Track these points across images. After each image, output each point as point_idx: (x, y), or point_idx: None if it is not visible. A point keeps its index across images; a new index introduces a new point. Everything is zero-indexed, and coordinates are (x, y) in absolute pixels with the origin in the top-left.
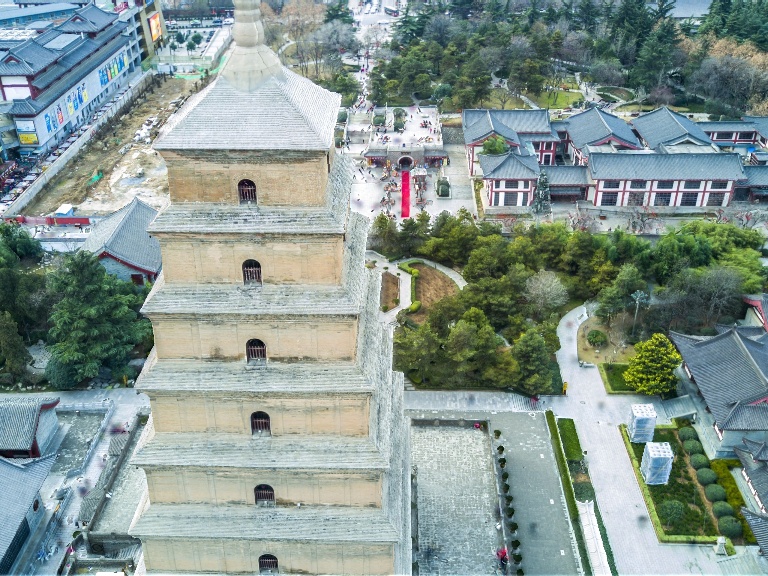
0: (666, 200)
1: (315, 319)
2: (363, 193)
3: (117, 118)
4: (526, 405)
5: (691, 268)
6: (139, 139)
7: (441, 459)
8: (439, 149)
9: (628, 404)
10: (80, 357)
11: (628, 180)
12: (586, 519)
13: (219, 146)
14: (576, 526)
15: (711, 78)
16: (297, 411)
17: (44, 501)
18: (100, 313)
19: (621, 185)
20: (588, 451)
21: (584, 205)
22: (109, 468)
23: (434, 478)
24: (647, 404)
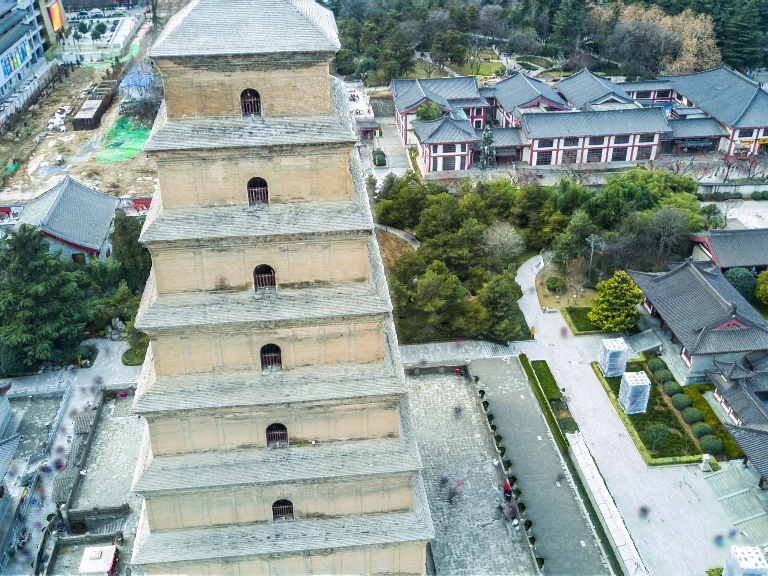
0: (598, 156)
1: (328, 237)
2: None
3: (25, 109)
4: (498, 351)
5: (638, 211)
6: (53, 128)
7: (427, 406)
8: (371, 120)
9: (595, 343)
10: (29, 338)
11: (561, 138)
12: (578, 449)
13: (221, 51)
14: (567, 458)
15: (626, 41)
16: (310, 340)
17: (8, 489)
18: (48, 290)
19: (555, 144)
20: (565, 389)
21: (520, 166)
22: (77, 447)
23: (423, 424)
24: (617, 338)
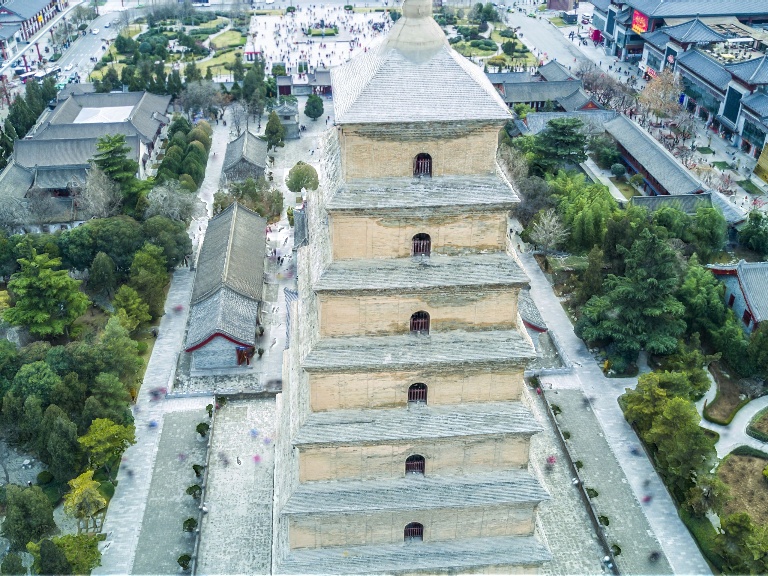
0: None
1: None
2: None
3: None
4: None
5: None
6: None
7: None
8: None
9: None
10: (593, 317)
11: None
12: None
13: None
14: None
15: None
16: None
17: None
18: (628, 296)
19: None
20: None
21: None
22: None
23: None
24: None
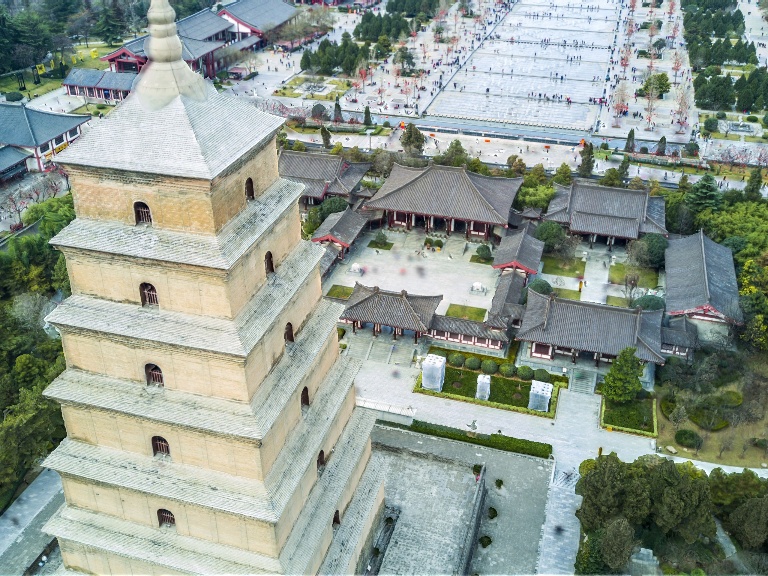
0: None
1: None
2: None
3: None
4: None
5: None
6: None
7: None
8: None
9: None
10: None
11: None
12: None
13: (243, 151)
14: None
15: None
16: None
17: None
18: None
19: None
20: None
21: None
22: None
23: None
24: None
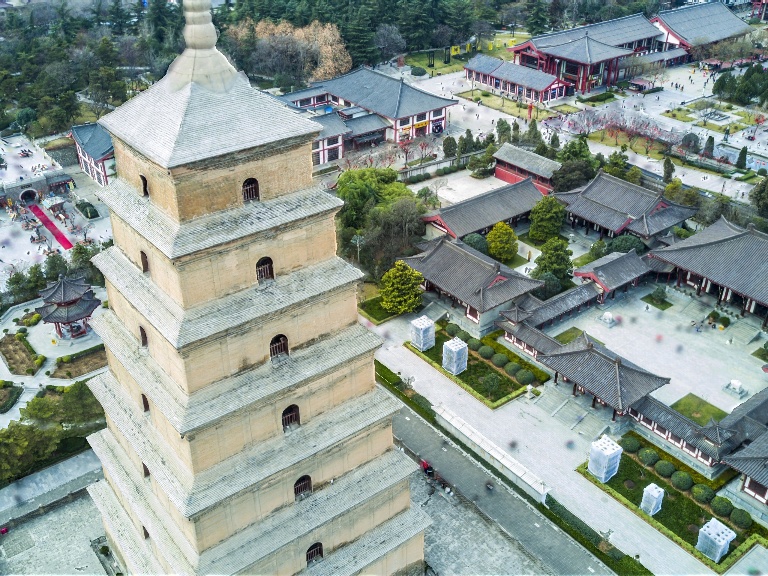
0: None
1: (329, 294)
2: (3, 239)
3: None
4: None
5: (376, 207)
6: None
7: None
8: (60, 174)
9: (396, 327)
10: None
11: None
12: (448, 415)
13: (231, 149)
14: (438, 427)
15: (273, 56)
16: (321, 390)
17: None
18: None
19: None
20: None
21: None
22: None
23: None
24: (421, 317)
